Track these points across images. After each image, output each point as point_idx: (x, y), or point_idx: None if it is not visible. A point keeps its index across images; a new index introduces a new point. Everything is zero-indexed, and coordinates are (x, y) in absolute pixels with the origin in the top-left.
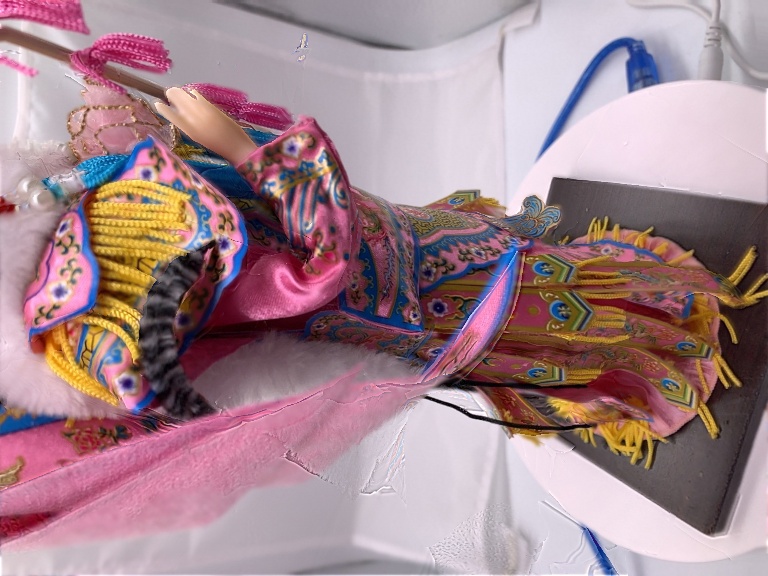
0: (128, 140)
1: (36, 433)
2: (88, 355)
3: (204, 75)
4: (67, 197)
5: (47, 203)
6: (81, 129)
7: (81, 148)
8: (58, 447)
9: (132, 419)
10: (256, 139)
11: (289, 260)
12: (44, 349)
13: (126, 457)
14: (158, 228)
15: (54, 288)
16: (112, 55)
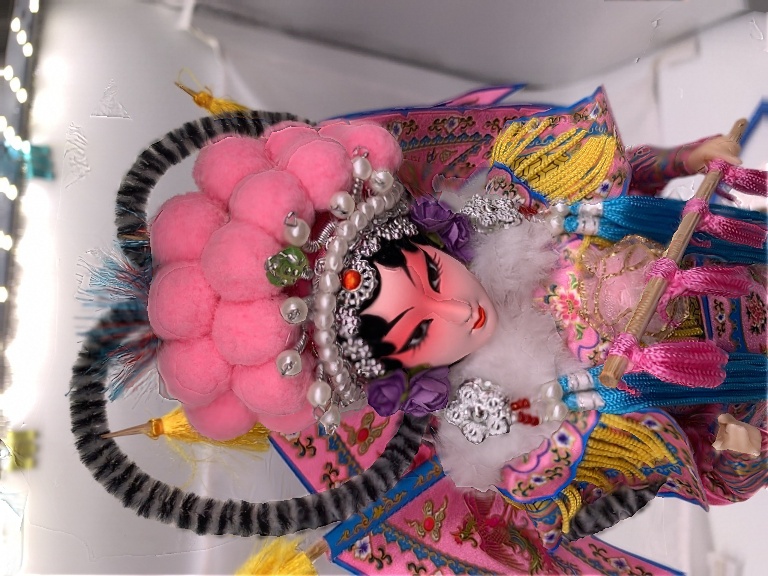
0: None
1: None
2: (533, 508)
3: None
4: (576, 411)
5: (561, 419)
6: None
7: (592, 308)
8: None
9: None
10: None
11: None
12: None
13: None
14: None
15: (536, 477)
16: None
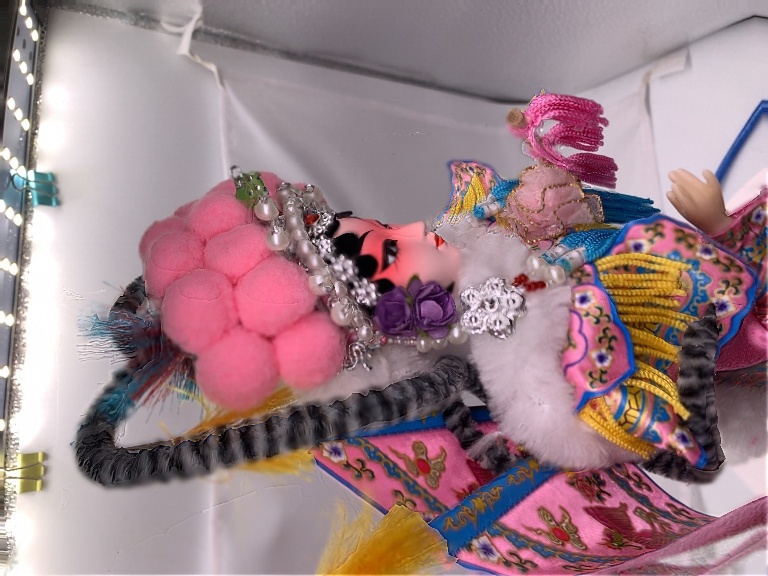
0: (570, 214)
1: (552, 484)
2: (634, 413)
3: (472, 135)
4: (573, 271)
5: (564, 278)
6: (543, 207)
7: (527, 223)
8: (575, 496)
9: (618, 467)
10: (607, 199)
11: (755, 317)
12: (580, 409)
13: (766, 506)
14: (660, 295)
15: (596, 355)
16: (567, 141)
